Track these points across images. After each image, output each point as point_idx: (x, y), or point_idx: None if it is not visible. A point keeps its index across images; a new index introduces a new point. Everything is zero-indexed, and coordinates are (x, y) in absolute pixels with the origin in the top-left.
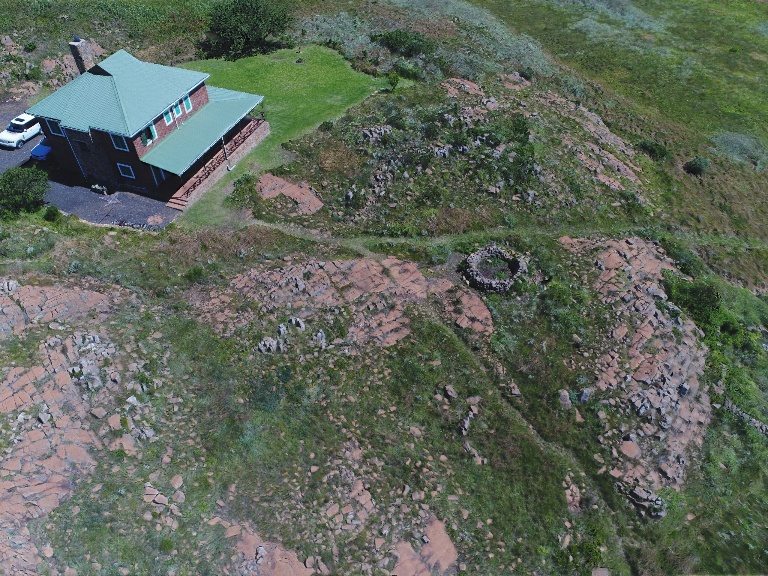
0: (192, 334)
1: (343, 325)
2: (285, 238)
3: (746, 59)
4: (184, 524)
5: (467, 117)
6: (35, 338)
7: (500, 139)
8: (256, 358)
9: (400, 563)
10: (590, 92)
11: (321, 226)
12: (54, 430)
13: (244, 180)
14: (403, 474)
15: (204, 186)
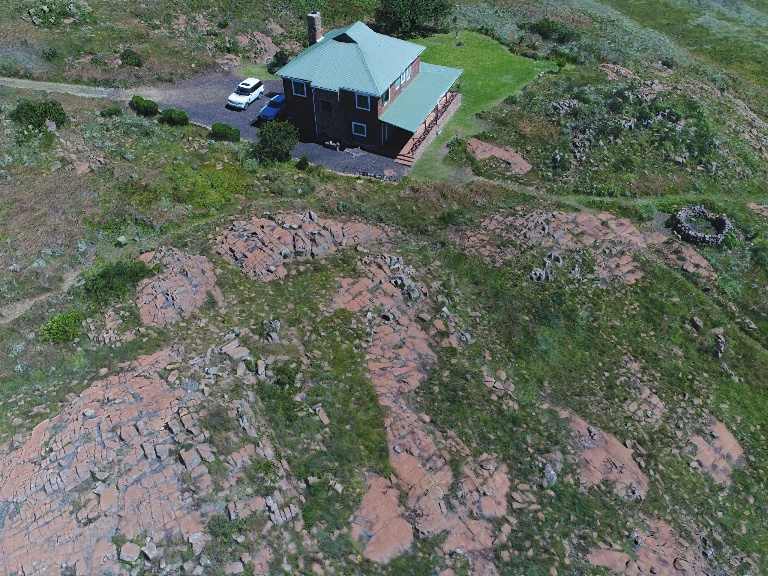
0: (467, 263)
1: None
2: (509, 192)
3: None
4: (524, 406)
5: (643, 95)
6: (351, 257)
7: None
8: (529, 285)
9: (700, 451)
10: (728, 82)
11: (536, 184)
12: (399, 327)
13: (456, 143)
14: (680, 384)
15: (423, 146)
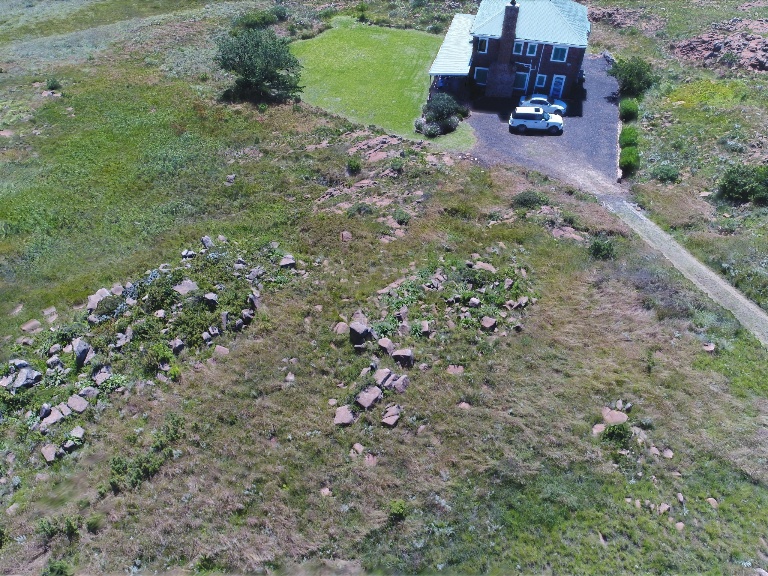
0: None
1: None
2: None
3: None
4: None
5: None
6: None
7: None
8: None
9: (714, 2)
10: None
11: None
12: None
13: None
14: (683, 2)
15: None
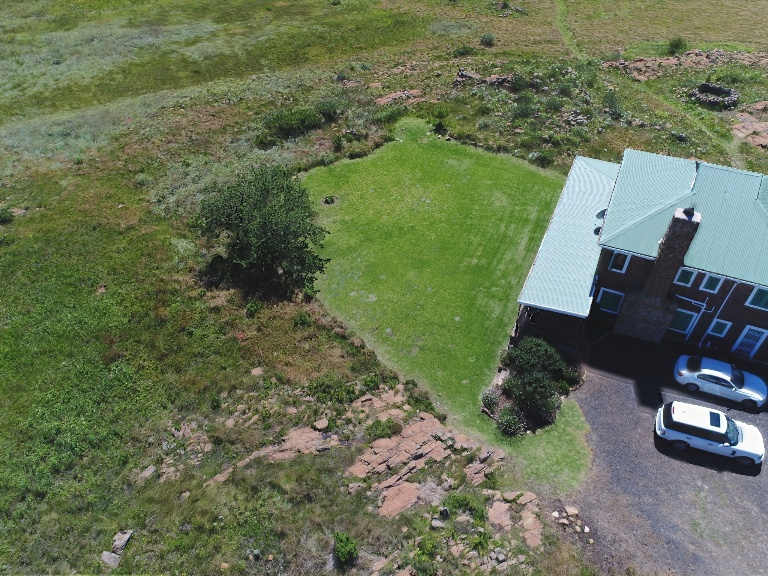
0: None
1: None
2: (764, 172)
3: (289, 8)
4: None
5: None
6: None
7: None
8: None
9: None
10: None
11: (725, 158)
12: None
13: None
14: None
15: None
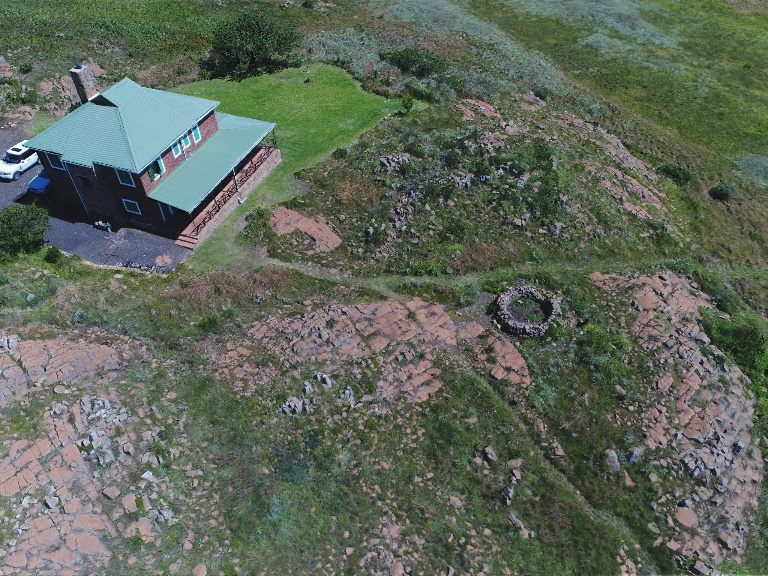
0: (209, 394)
1: (371, 379)
2: (303, 279)
3: (761, 76)
4: None
5: (488, 144)
6: (39, 405)
7: (523, 167)
8: (280, 421)
9: None
10: (607, 112)
11: (341, 265)
12: (63, 516)
13: (257, 214)
14: (446, 554)
15: (215, 221)
